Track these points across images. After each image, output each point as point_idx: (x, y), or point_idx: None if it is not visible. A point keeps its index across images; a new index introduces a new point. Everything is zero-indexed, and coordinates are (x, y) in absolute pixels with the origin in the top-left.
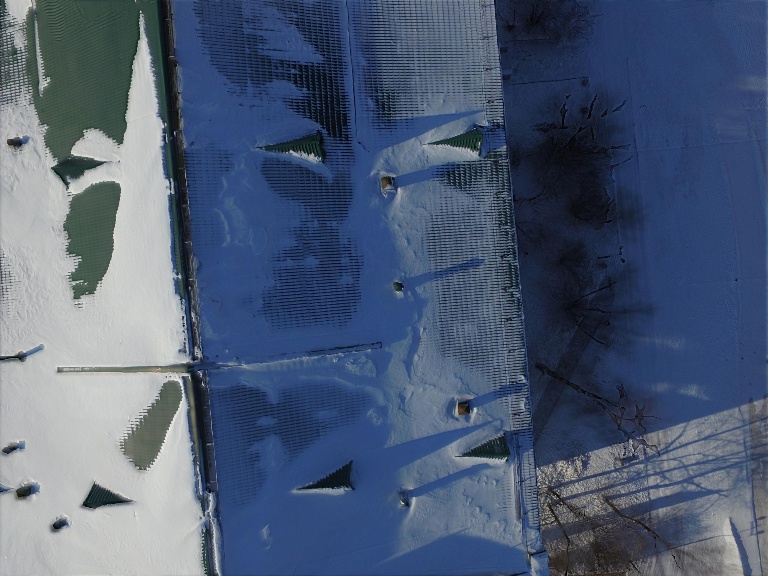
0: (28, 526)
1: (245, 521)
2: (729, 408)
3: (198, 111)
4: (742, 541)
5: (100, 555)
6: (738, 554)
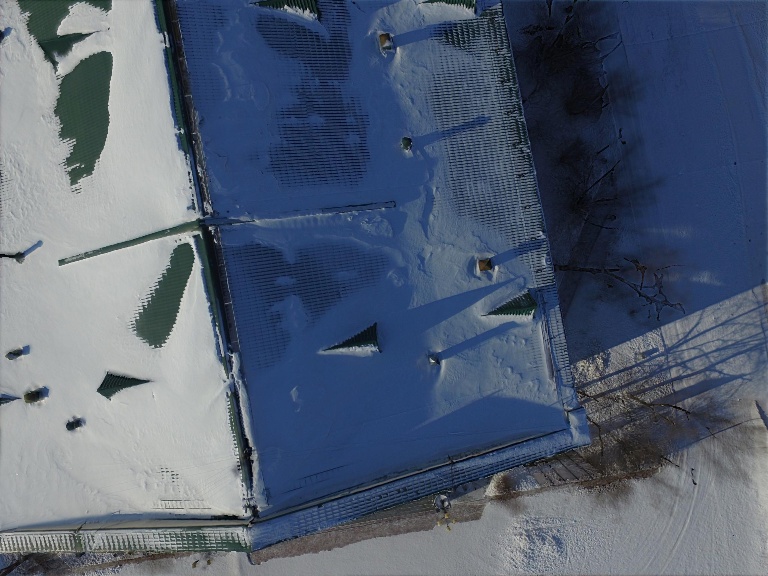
0: (39, 436)
1: (271, 384)
2: (742, 291)
3: None
4: None
5: (119, 451)
6: None
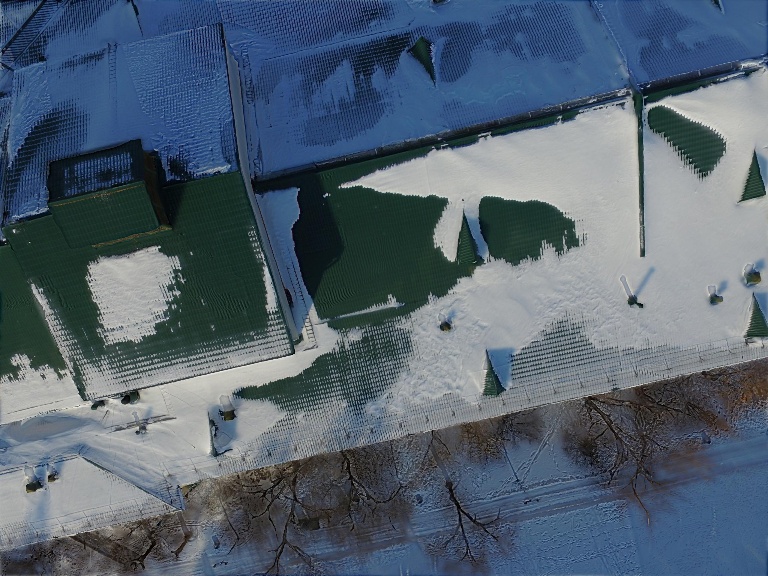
0: None
1: (759, 41)
2: None
3: (416, 128)
4: None
5: None
6: None
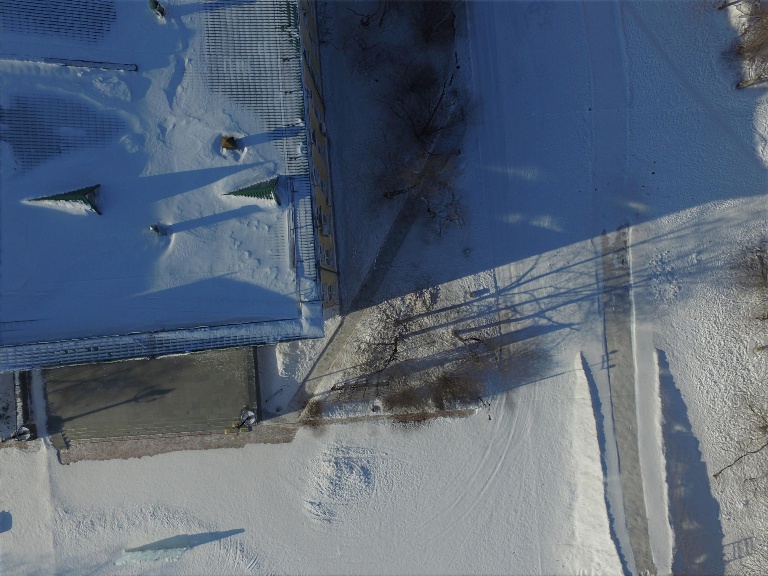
0: None
1: None
2: (581, 240)
3: None
4: (592, 375)
5: None
6: (587, 387)
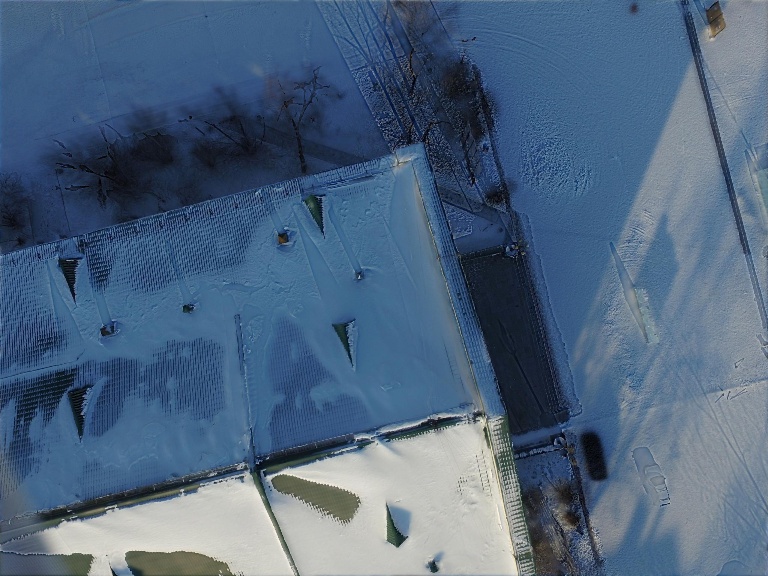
0: None
1: (380, 407)
2: (315, 3)
3: (52, 495)
4: None
5: (450, 528)
6: None
